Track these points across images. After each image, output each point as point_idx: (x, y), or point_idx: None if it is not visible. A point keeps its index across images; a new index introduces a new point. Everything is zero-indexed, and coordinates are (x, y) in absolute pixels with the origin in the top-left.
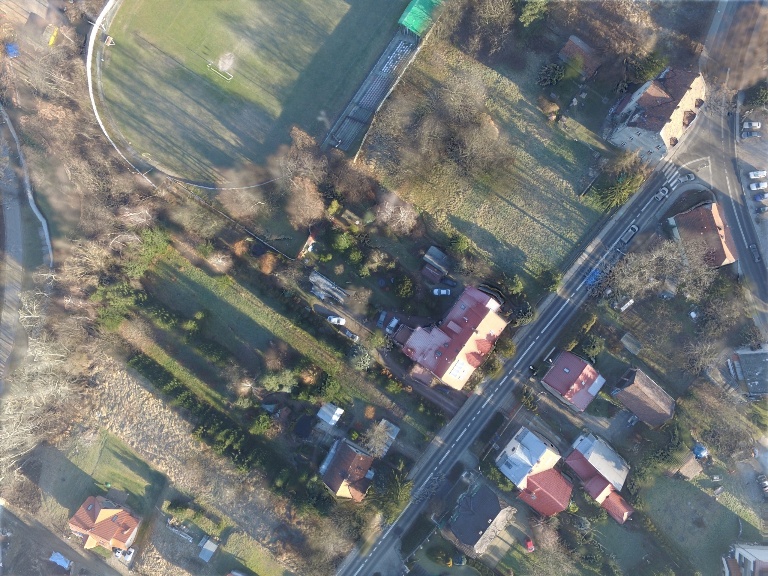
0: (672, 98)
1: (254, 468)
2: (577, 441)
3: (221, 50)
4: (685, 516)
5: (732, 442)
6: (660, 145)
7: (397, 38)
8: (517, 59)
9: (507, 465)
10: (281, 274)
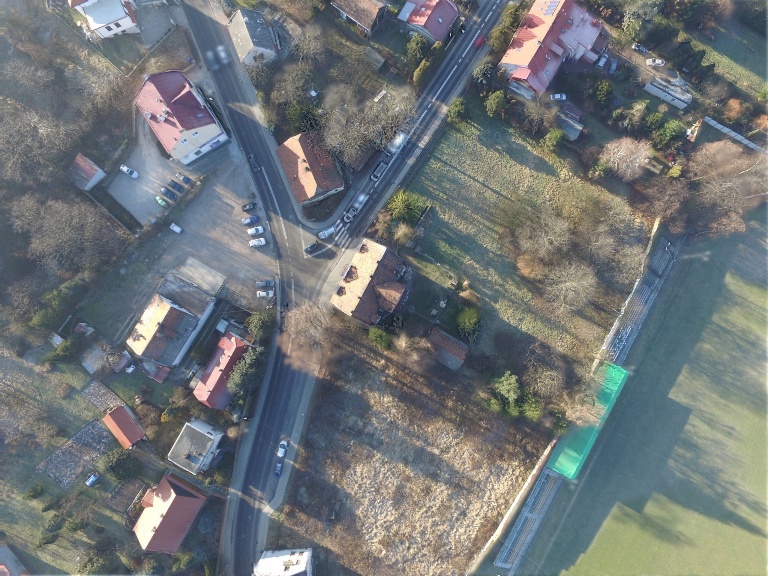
0: (375, 288)
1: None
2: None
3: None
4: None
5: None
6: None
7: None
8: (507, 342)
9: None
10: None
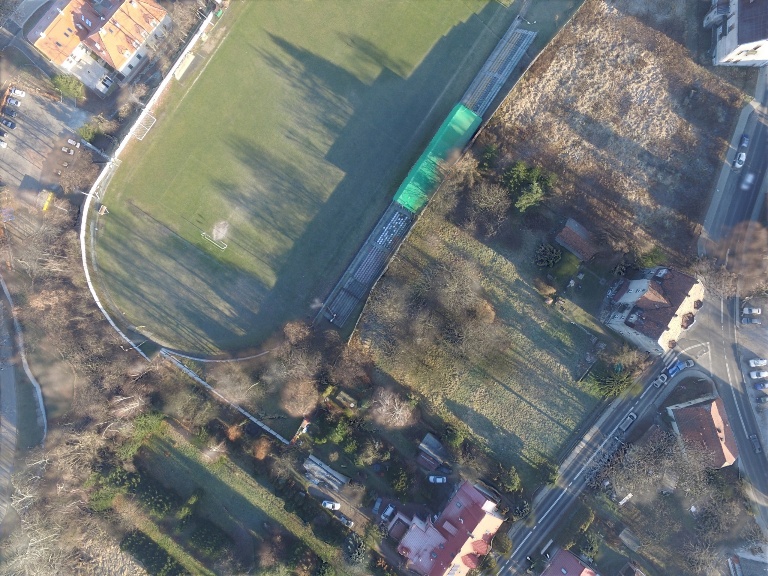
0: (670, 304)
1: None
2: None
3: (215, 219)
4: None
5: None
6: (658, 349)
7: (392, 208)
8: (513, 240)
9: None
10: (275, 454)
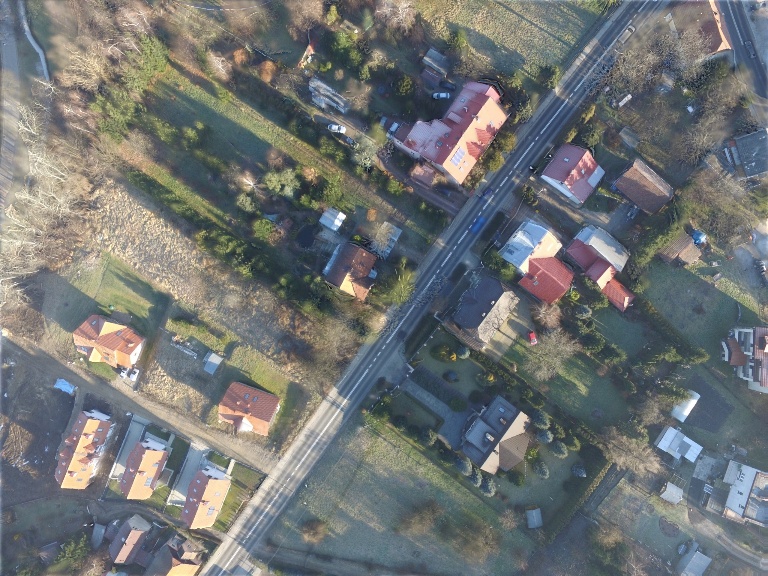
0: None
1: (257, 281)
2: (577, 234)
3: None
4: (685, 304)
5: (730, 228)
6: None
7: None
8: None
9: (509, 252)
10: (281, 87)
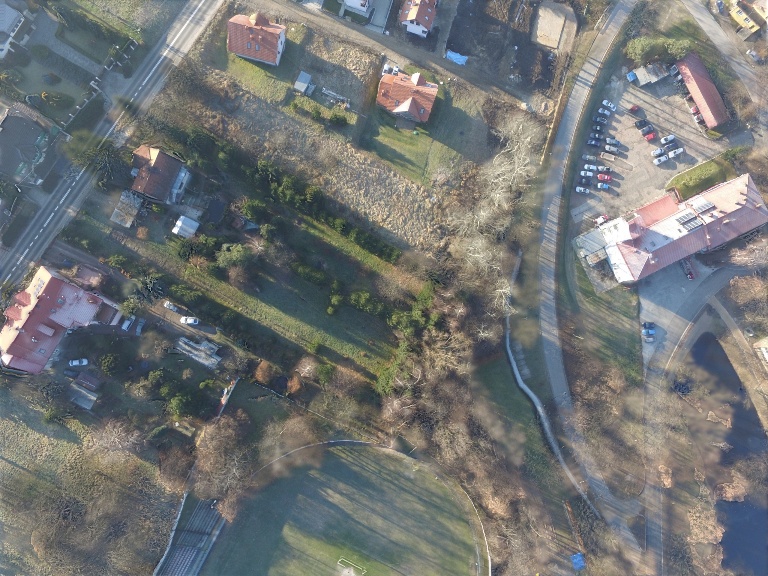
0: None
1: None
2: None
3: None
4: None
5: None
6: None
7: None
8: None
9: None
10: (255, 361)
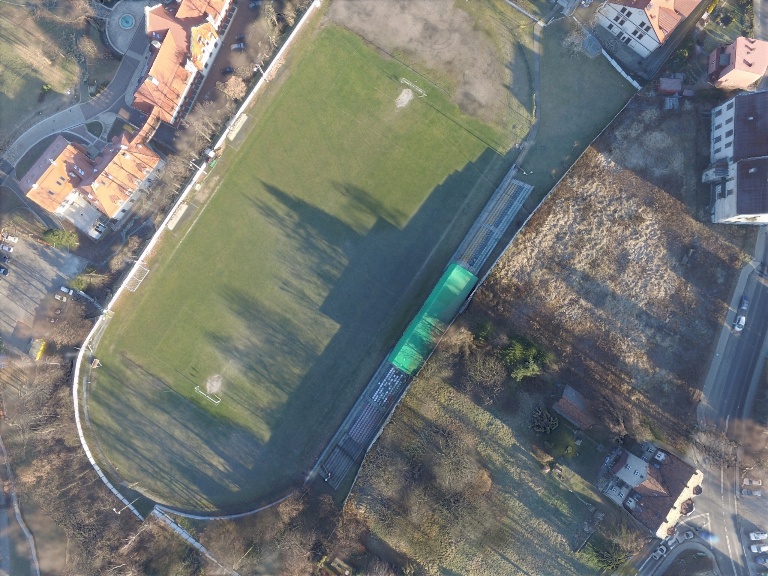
0: (669, 494)
1: None
2: None
3: (209, 372)
4: None
5: None
6: None
7: (388, 362)
8: (510, 406)
9: None
10: None
